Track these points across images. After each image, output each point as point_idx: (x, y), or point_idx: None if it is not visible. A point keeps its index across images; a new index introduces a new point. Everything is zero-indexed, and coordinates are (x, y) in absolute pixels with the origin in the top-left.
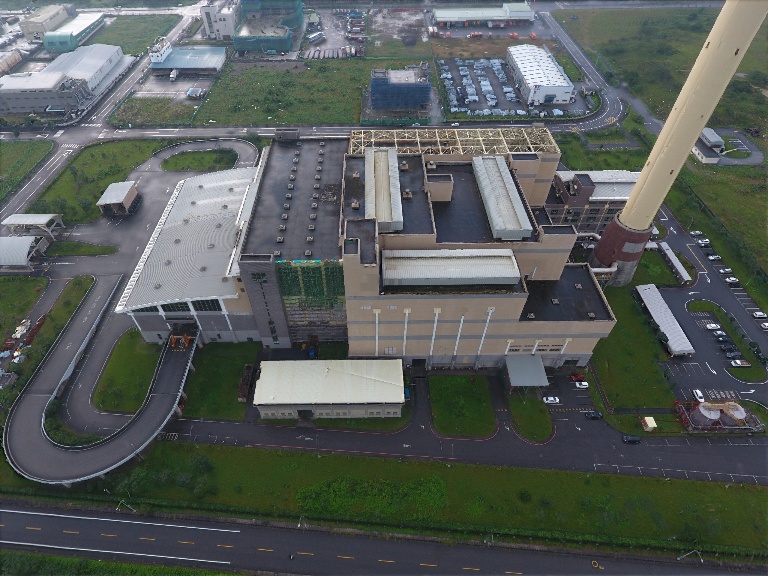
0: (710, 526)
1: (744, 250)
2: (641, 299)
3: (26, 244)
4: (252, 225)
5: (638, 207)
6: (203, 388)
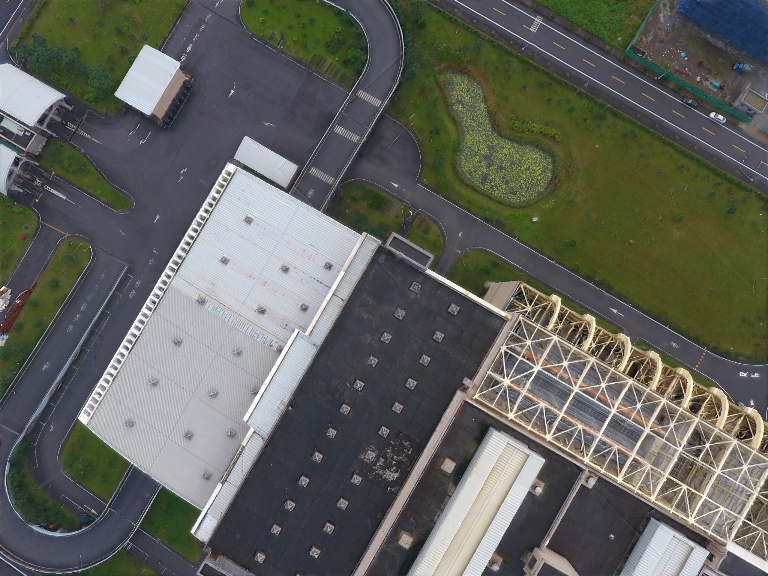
0: None
1: None
2: None
3: (3, 165)
4: (253, 472)
5: None
6: (170, 505)
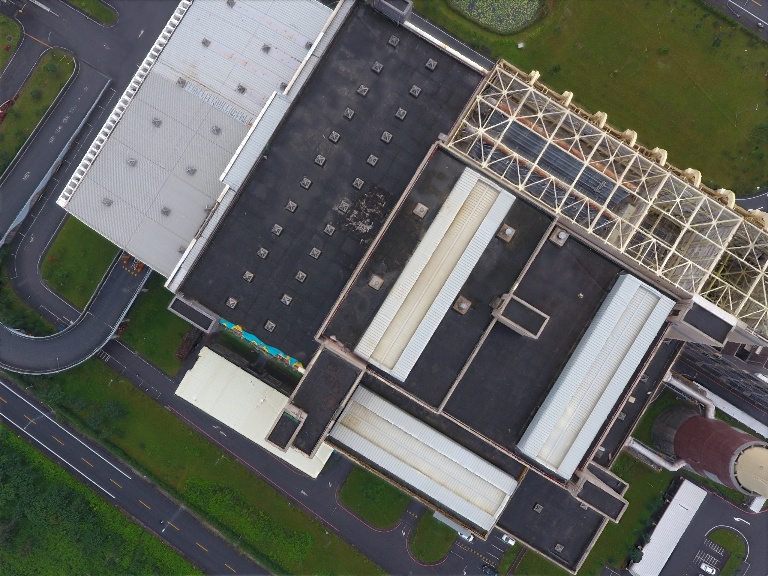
0: None
1: None
2: (672, 497)
3: None
4: (227, 220)
5: None
6: (148, 318)
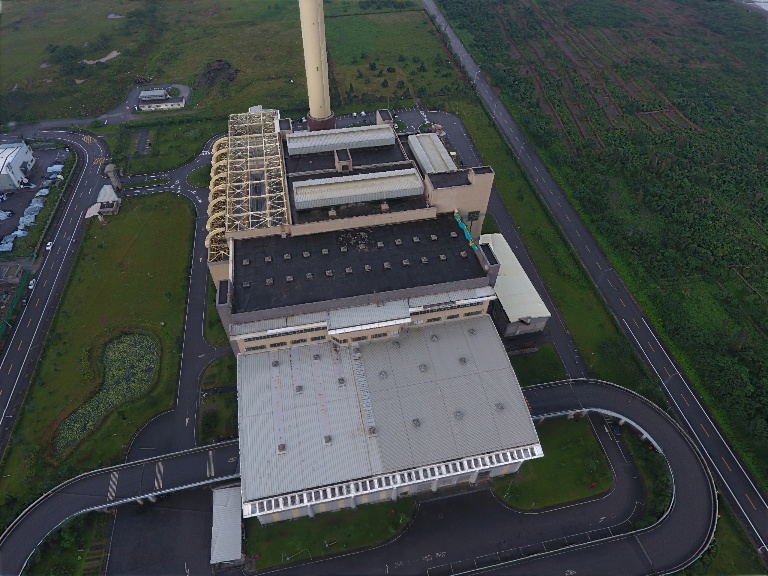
0: (504, 144)
1: (308, 103)
2: None
3: None
4: None
5: (327, 99)
6: None
